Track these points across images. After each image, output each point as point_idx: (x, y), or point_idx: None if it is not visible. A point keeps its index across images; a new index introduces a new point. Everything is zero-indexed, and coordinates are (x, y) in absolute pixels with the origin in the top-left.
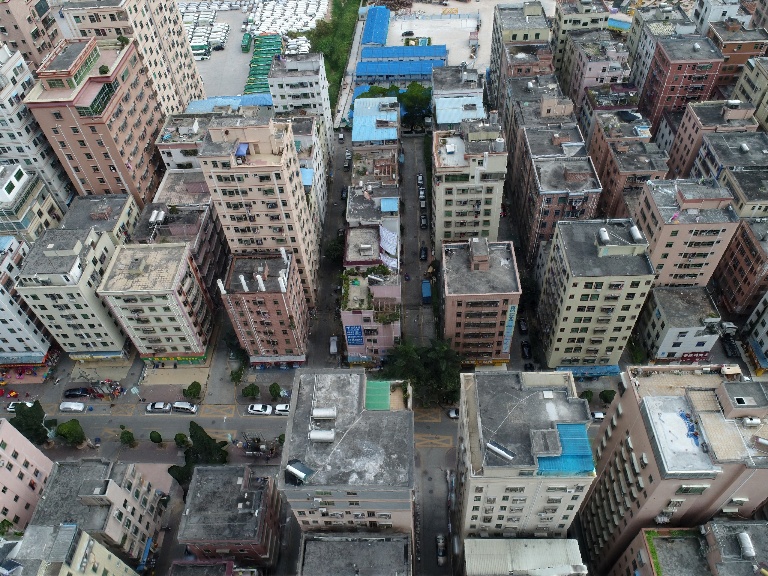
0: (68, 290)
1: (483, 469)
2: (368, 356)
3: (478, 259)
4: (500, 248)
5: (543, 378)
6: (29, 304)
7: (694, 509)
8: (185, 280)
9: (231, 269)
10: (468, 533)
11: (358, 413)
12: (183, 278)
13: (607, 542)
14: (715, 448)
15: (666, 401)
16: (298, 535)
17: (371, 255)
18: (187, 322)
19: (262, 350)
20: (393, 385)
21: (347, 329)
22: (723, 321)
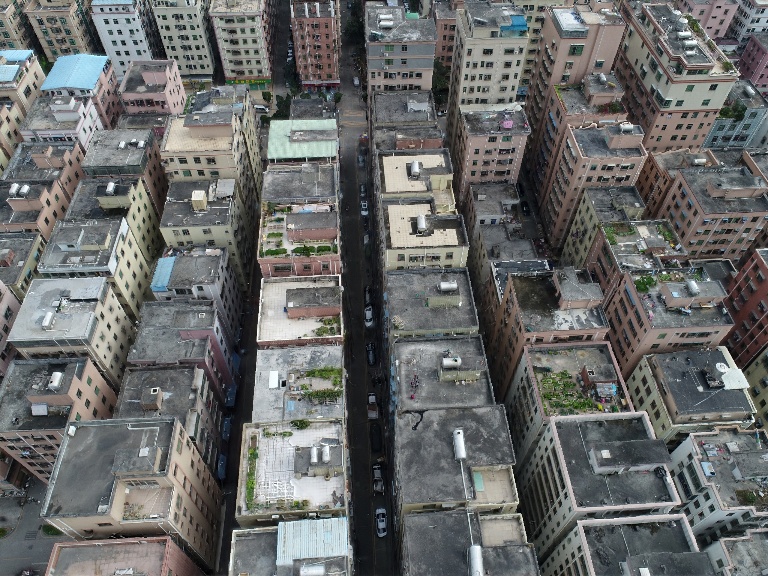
0: (189, 11)
1: (473, 30)
2: None
3: (457, 0)
4: None
5: (501, 4)
6: (158, 24)
7: (579, 77)
8: (264, 13)
9: (294, 7)
10: None
11: (403, 20)
12: (263, 10)
13: (535, 128)
14: (587, 21)
15: (564, 10)
16: (349, 163)
17: None
18: (264, 45)
19: (311, 75)
20: (419, 18)
21: None
22: (611, 71)
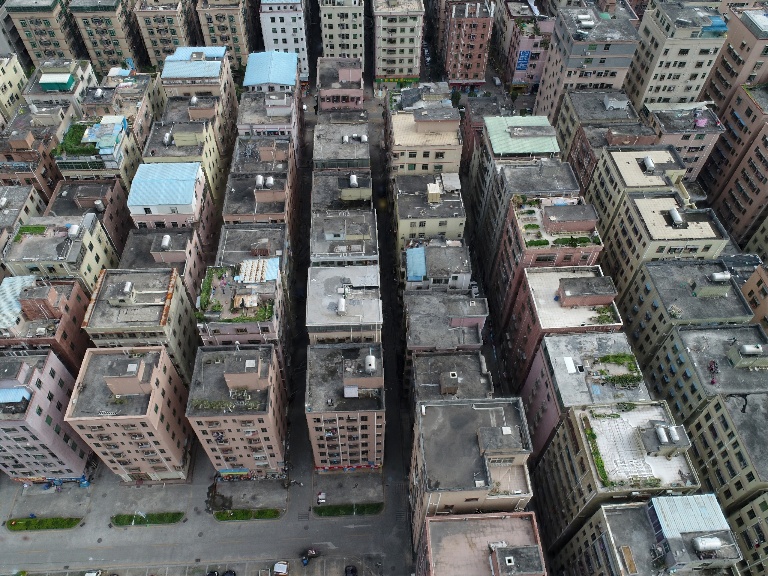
0: (355, 10)
1: (675, 30)
2: (525, 81)
3: (609, 2)
4: (617, 3)
5: (692, 5)
6: (323, 23)
7: (764, 77)
8: None
9: (450, 8)
10: (640, 110)
11: (599, 20)
12: None
13: None
14: None
15: (756, 12)
16: None
17: (527, 14)
18: (420, 44)
19: (458, 74)
20: None
21: (520, 54)
22: None
